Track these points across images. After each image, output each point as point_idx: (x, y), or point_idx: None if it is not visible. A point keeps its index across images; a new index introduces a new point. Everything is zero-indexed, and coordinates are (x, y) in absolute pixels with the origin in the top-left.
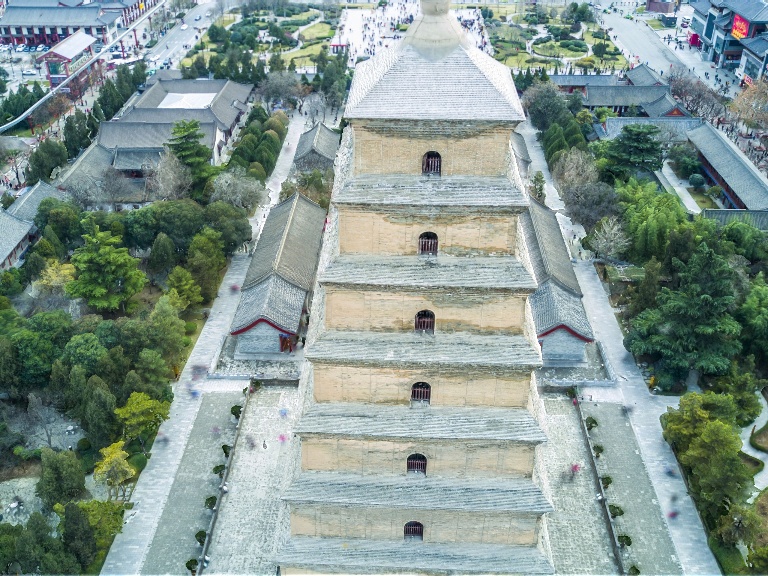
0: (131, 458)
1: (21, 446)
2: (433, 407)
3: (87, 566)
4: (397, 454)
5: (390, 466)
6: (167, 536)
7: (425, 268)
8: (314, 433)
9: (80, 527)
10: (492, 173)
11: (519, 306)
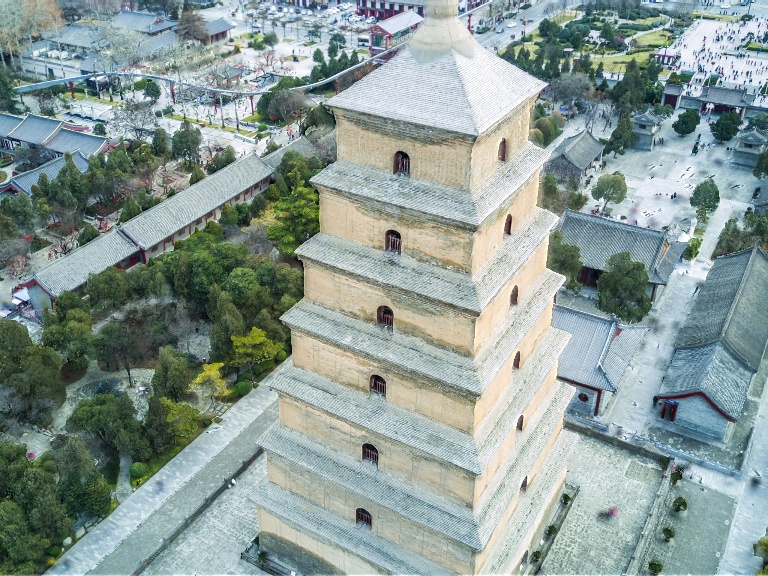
0: (239, 382)
1: (172, 346)
2: (388, 404)
3: (161, 454)
4: (354, 438)
5: (348, 448)
6: (230, 455)
7: (386, 264)
8: (285, 392)
9: (157, 419)
10: (455, 185)
11: (468, 327)
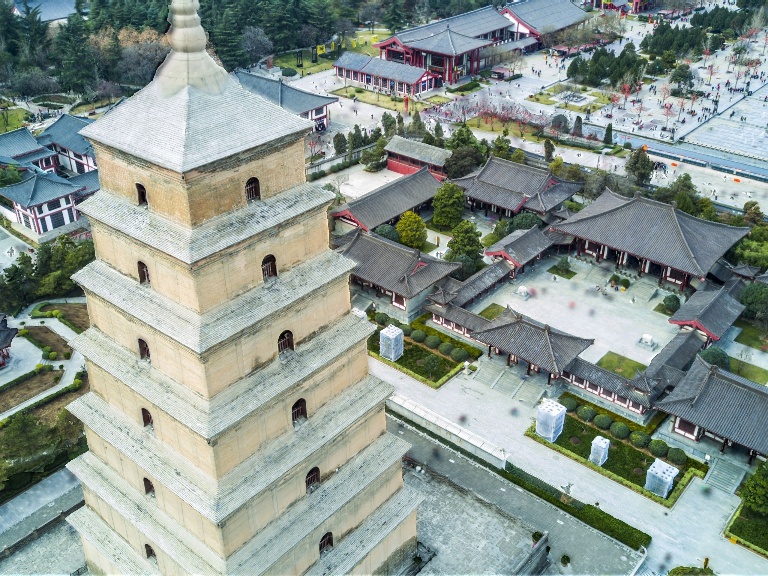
0: None
1: None
2: None
3: None
4: None
5: None
6: None
7: None
8: None
9: None
10: None
11: None
